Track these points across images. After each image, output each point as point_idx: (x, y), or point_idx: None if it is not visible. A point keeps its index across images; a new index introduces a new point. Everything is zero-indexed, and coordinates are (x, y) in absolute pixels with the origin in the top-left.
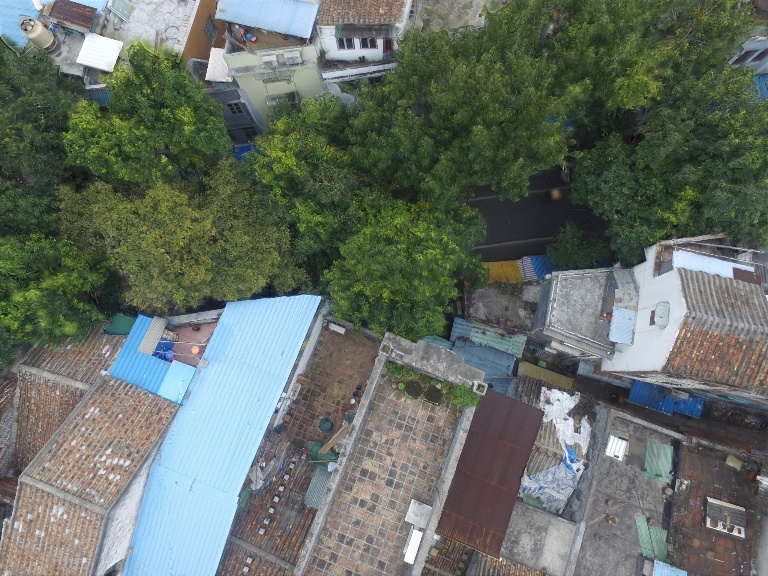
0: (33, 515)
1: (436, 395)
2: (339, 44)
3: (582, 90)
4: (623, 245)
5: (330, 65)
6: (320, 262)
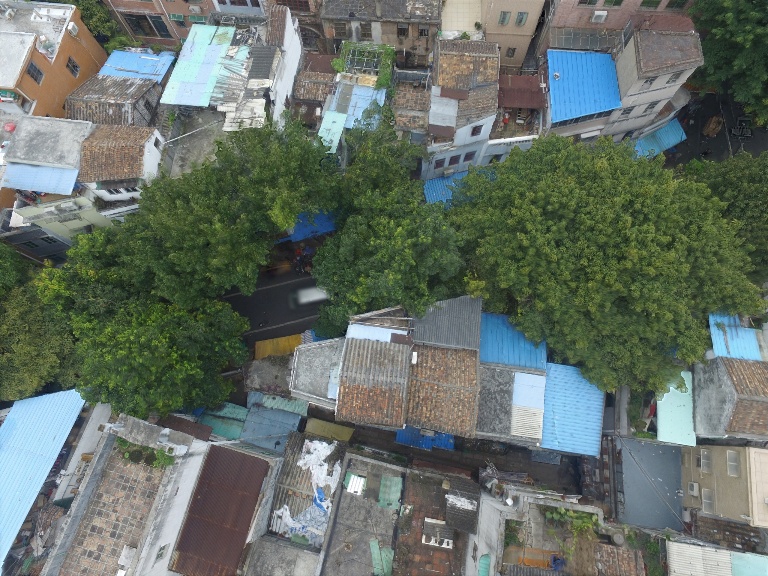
0: None
1: (152, 459)
2: (109, 191)
3: (246, 221)
4: (336, 320)
5: (111, 204)
6: None
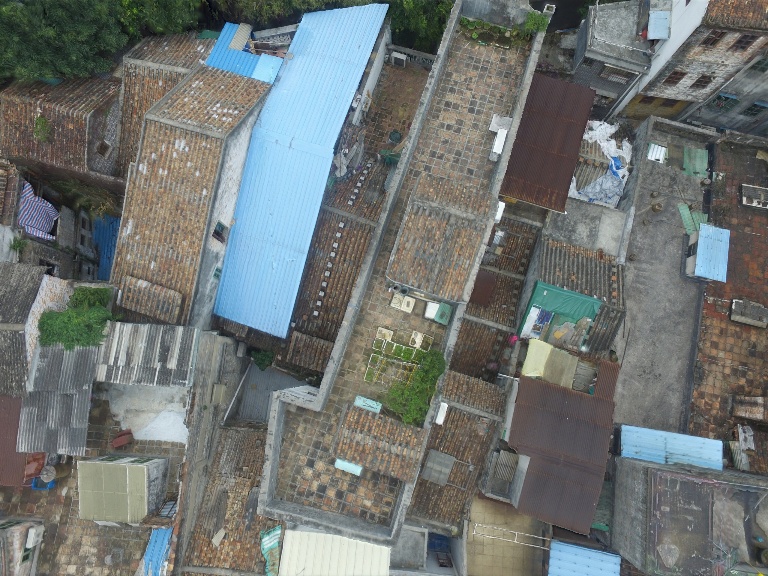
0: (156, 155)
1: (506, 39)
2: None
3: None
4: None
5: None
6: None
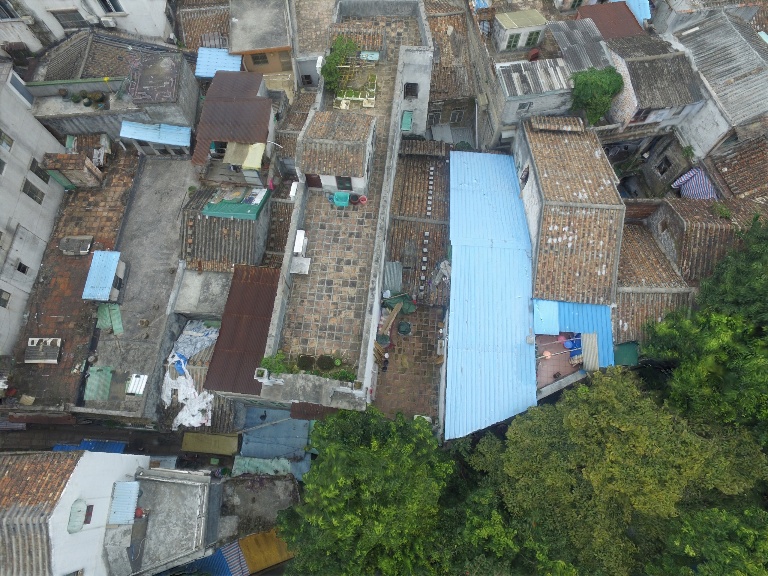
0: (600, 190)
1: (304, 363)
2: None
3: None
4: None
5: None
6: (465, 491)
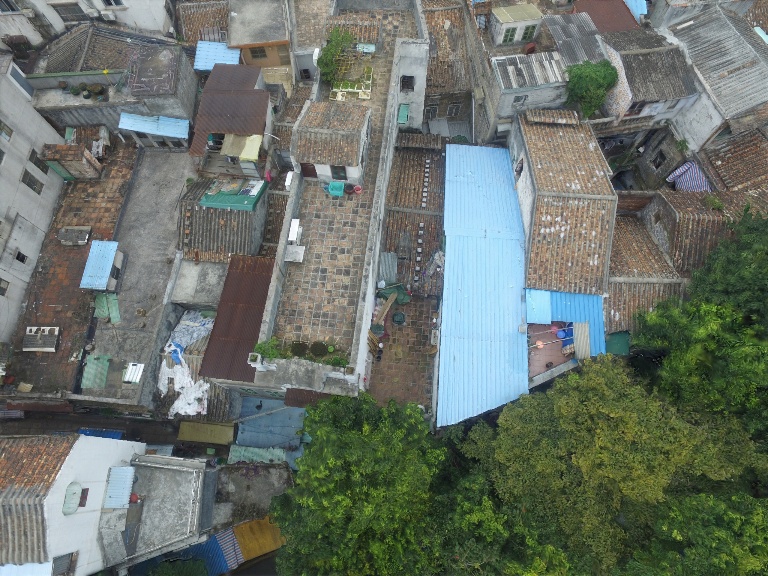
0: (593, 181)
1: (297, 349)
2: None
3: None
4: None
5: None
6: (458, 478)
